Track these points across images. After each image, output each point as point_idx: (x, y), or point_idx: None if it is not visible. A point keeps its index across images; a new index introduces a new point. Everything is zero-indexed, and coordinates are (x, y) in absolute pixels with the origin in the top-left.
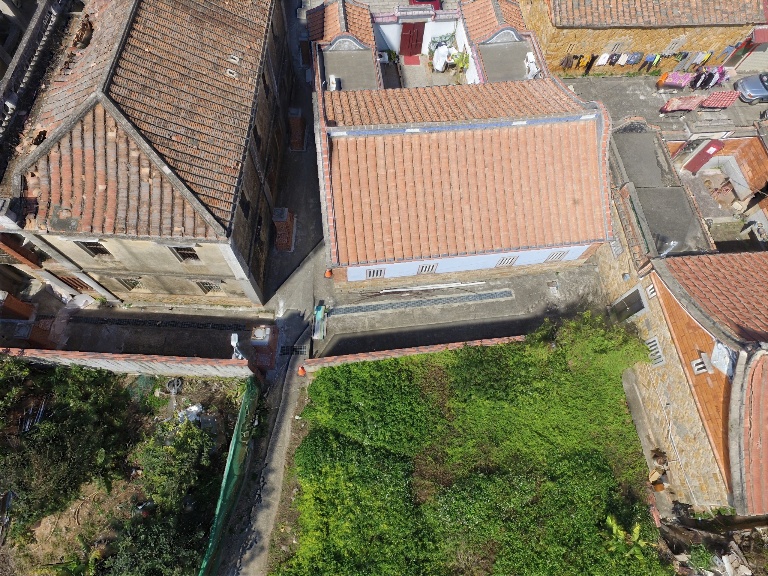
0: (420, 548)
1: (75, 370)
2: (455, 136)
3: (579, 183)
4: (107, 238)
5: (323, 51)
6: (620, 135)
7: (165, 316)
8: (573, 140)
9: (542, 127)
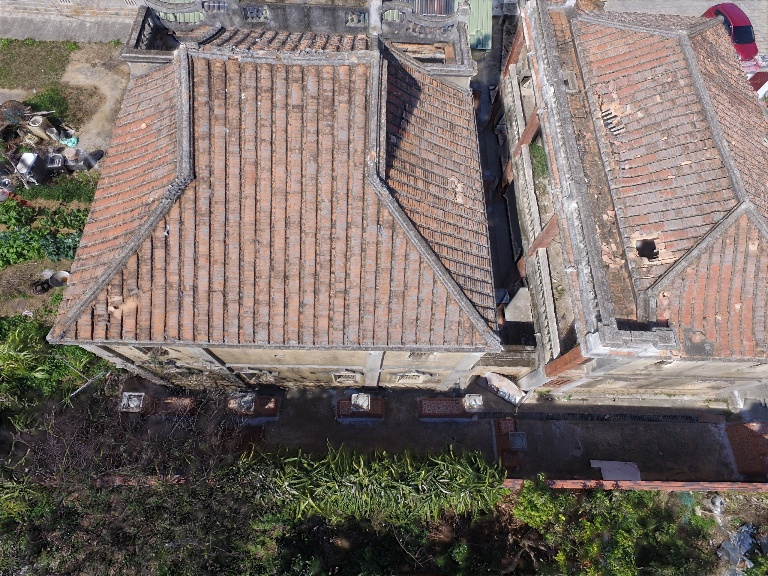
0: None
1: (649, 498)
2: None
3: None
4: (743, 362)
5: None
6: None
7: (610, 408)
8: None
9: None
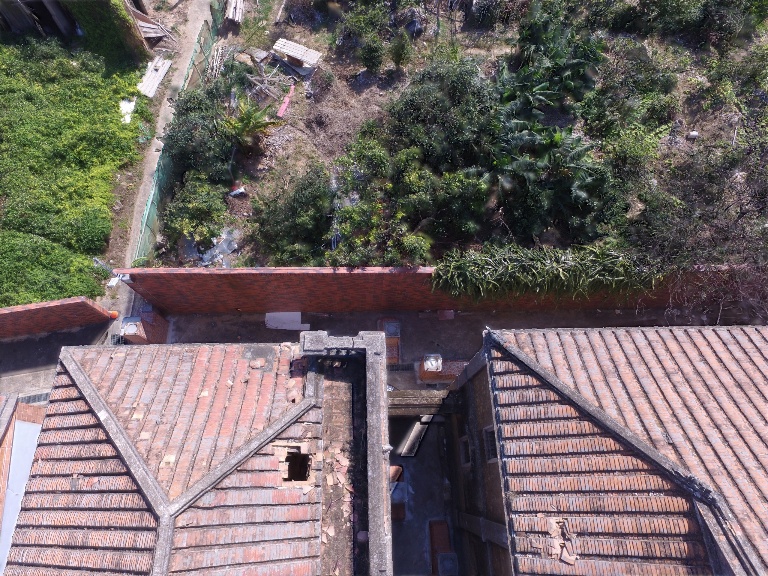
0: (4, 162)
1: None
2: None
3: None
4: (211, 344)
5: None
6: None
7: None
8: None
9: None
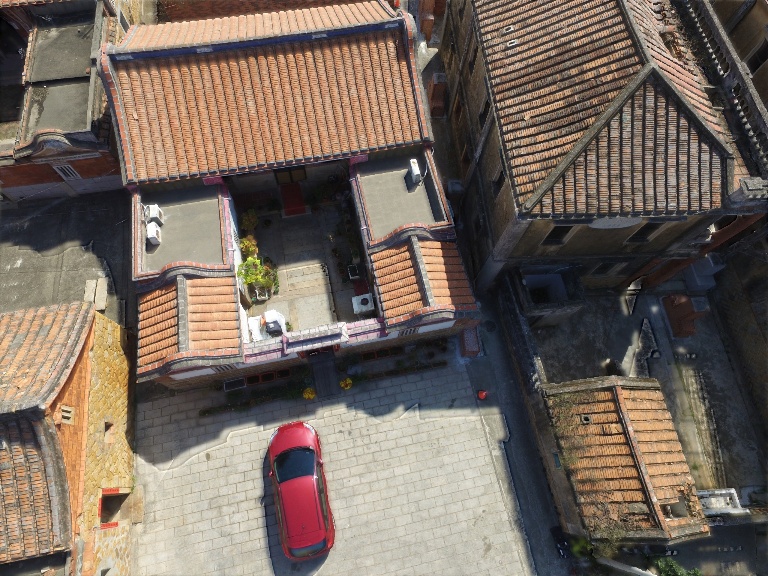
0: None
1: None
2: None
3: None
4: None
5: None
6: None
7: None
8: None
9: None
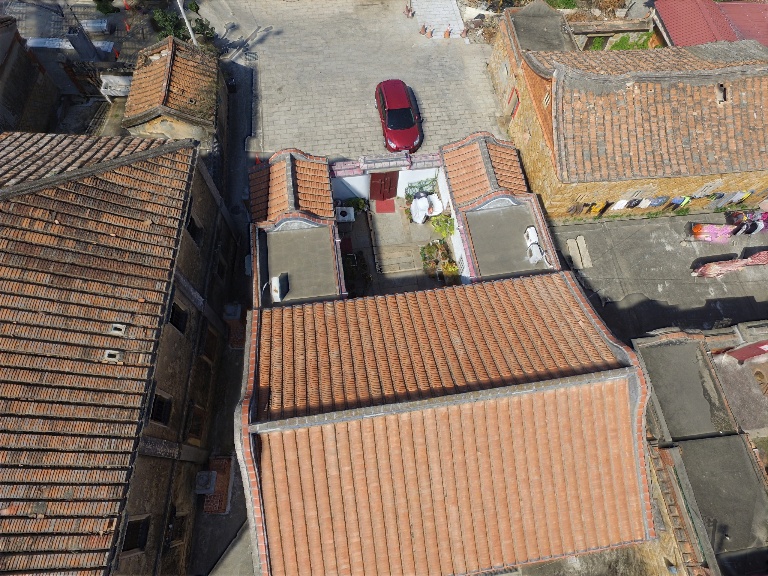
0: None
1: None
2: (434, 412)
3: (607, 463)
4: None
5: (266, 232)
6: (653, 350)
7: None
8: (597, 406)
9: (554, 391)
